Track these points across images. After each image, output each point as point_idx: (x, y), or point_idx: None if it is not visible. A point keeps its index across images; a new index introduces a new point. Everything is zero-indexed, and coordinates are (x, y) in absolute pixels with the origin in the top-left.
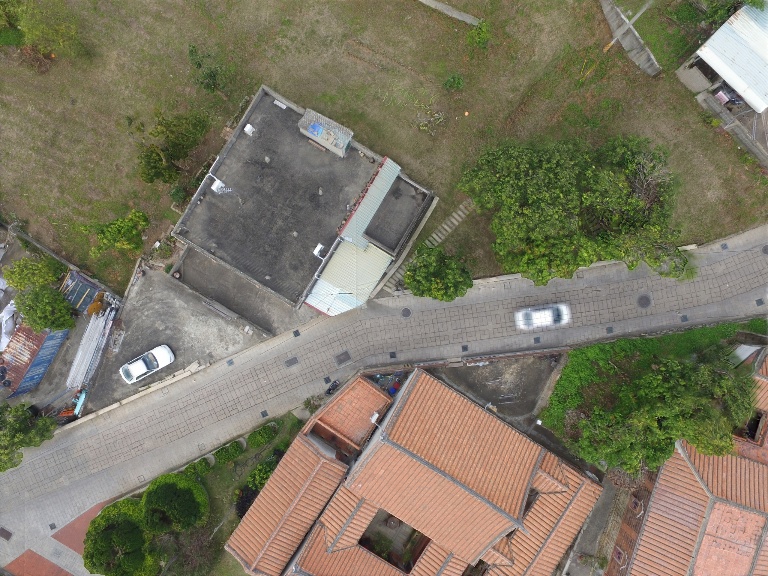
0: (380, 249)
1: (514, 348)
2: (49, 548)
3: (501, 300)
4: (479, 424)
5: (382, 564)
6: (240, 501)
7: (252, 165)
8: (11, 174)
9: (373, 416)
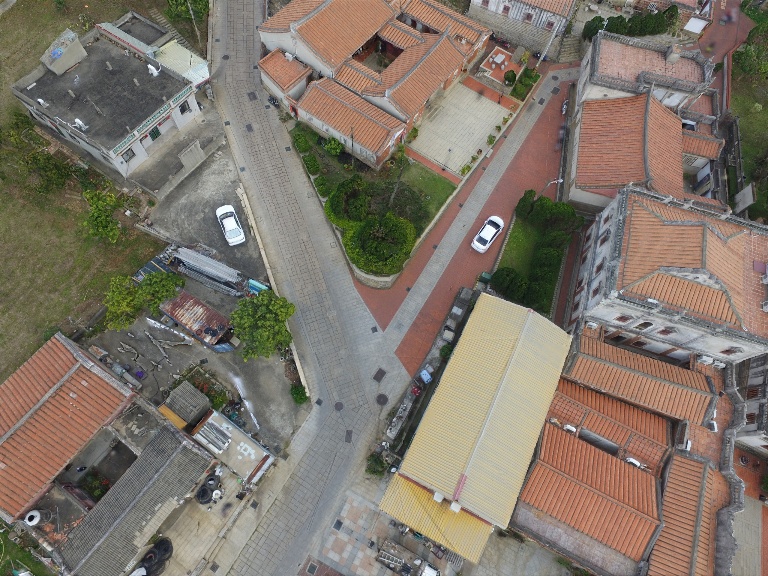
0: (165, 44)
1: (262, 2)
2: (394, 334)
3: (227, 6)
4: (300, 1)
5: (395, 61)
6: (356, 169)
7: (73, 106)
8: (22, 334)
9: (287, 57)
